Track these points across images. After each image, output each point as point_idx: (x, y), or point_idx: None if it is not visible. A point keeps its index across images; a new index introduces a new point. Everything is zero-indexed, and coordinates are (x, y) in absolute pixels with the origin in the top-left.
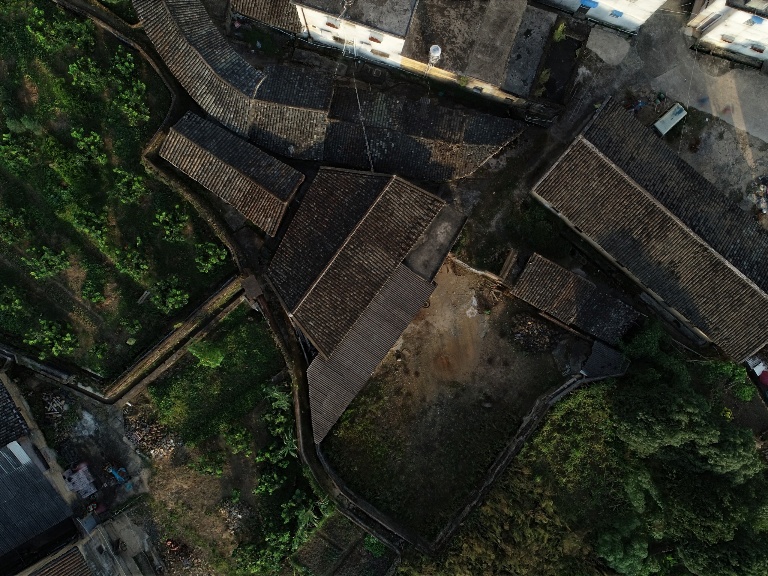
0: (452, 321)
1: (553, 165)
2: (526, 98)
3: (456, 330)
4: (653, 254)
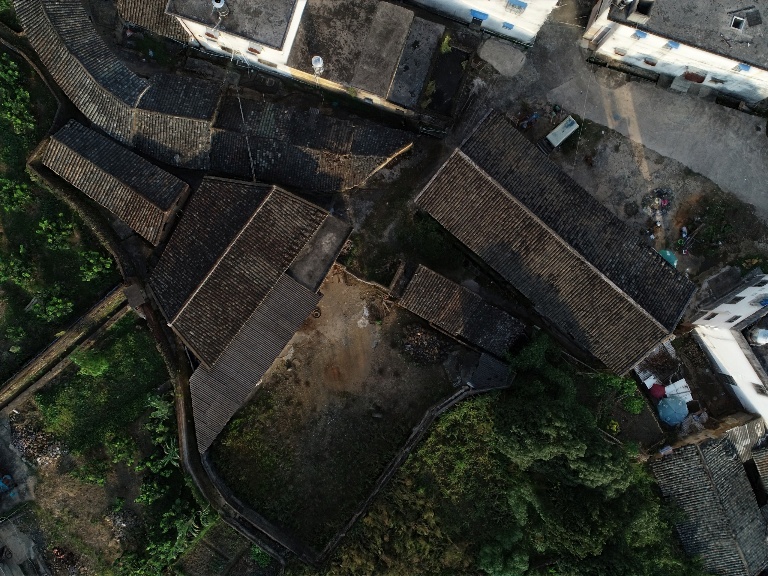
0: (343, 331)
1: None
2: (413, 109)
3: (347, 340)
4: (532, 267)
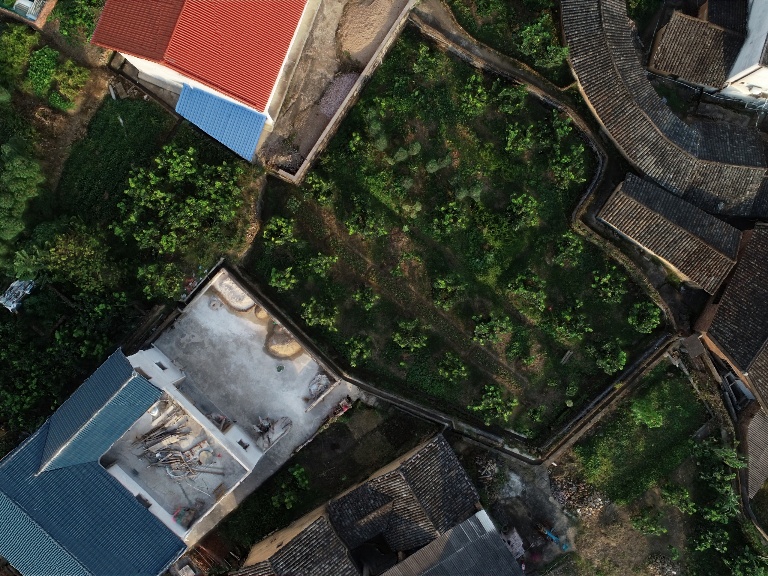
0: None
1: None
2: None
3: None
4: None
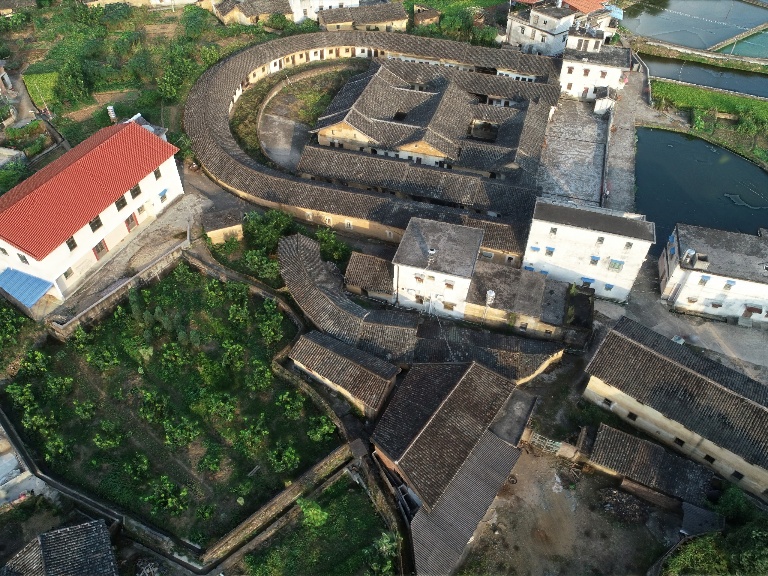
0: (541, 496)
1: (596, 351)
2: (561, 326)
3: (546, 504)
4: (701, 410)
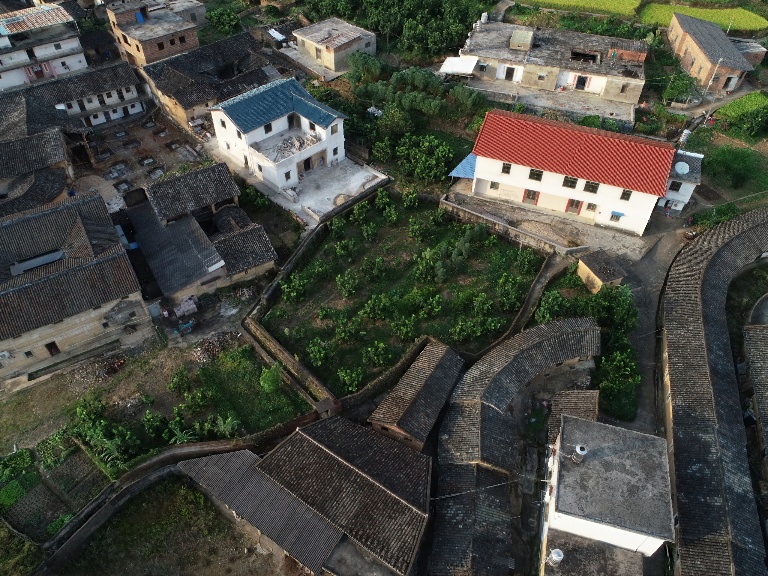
0: None
1: None
2: None
3: None
4: None
